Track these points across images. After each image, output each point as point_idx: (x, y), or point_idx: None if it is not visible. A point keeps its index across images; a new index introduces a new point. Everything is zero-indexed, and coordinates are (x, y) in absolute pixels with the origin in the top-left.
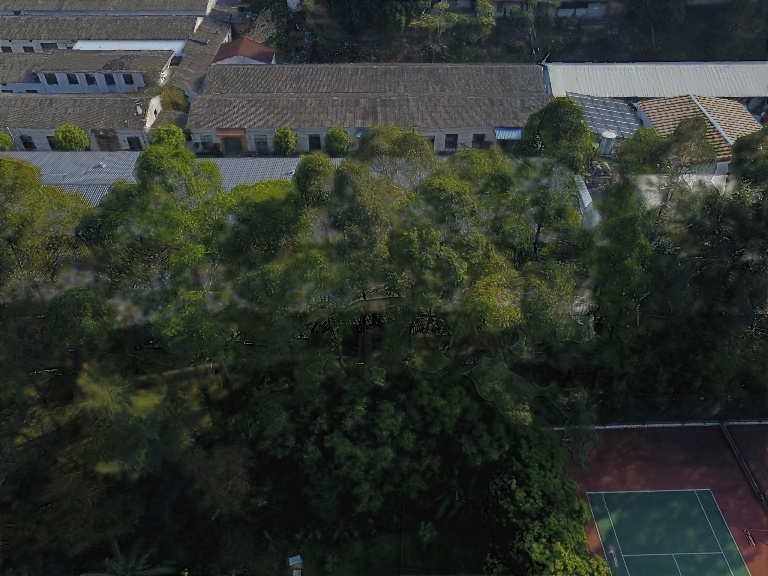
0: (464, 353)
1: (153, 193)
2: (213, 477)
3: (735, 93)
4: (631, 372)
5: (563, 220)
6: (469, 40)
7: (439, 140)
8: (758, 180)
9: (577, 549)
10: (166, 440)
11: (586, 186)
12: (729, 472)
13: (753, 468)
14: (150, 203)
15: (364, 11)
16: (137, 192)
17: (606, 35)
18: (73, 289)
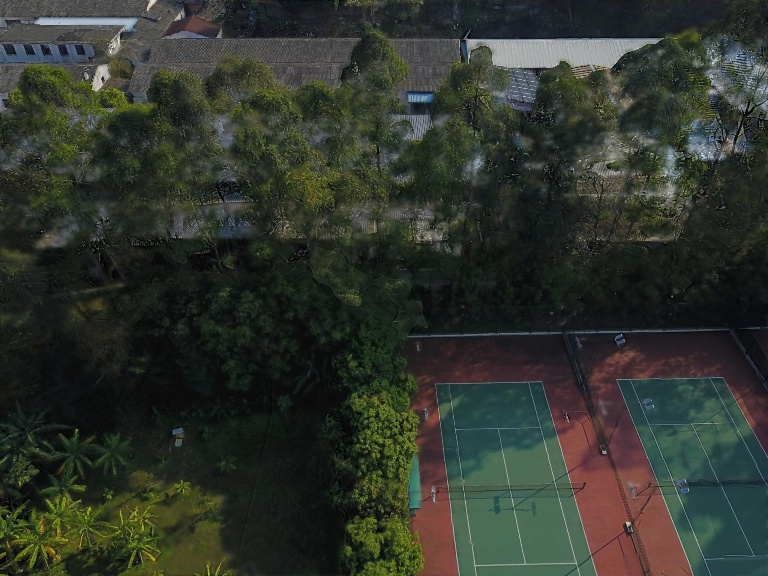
0: None
1: (35, 102)
2: (91, 341)
3: None
4: (481, 285)
5: (396, 141)
6: (400, 18)
7: None
8: (547, 103)
9: (396, 407)
10: (51, 309)
11: None
12: (561, 369)
13: (582, 366)
14: (32, 110)
15: None
16: (22, 102)
17: (528, 14)
18: None
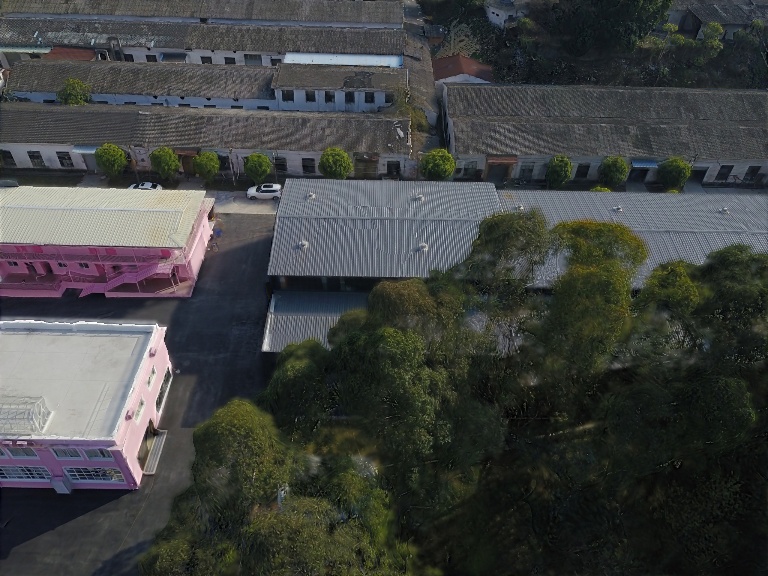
0: None
1: None
2: None
3: None
4: None
5: None
6: (690, 63)
7: (712, 171)
8: None
9: None
10: None
11: None
12: None
13: None
14: None
15: (597, 31)
16: None
17: None
18: (649, 365)
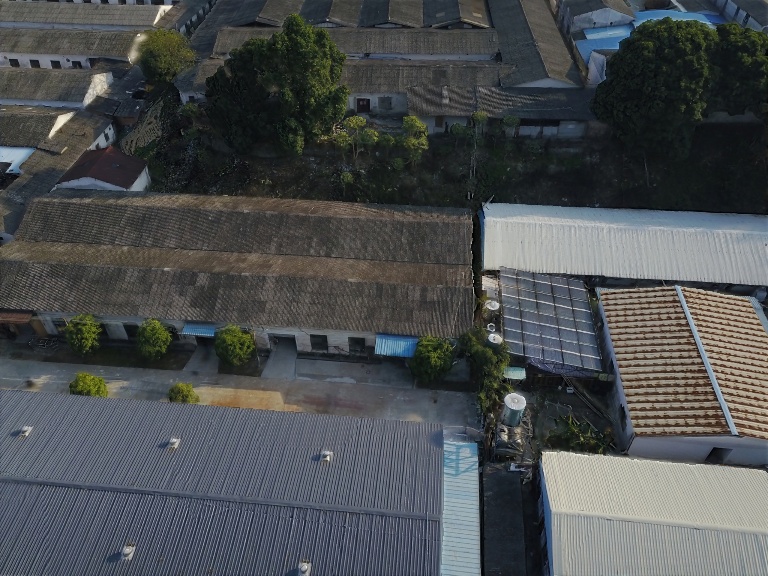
0: None
1: None
2: None
3: (749, 279)
4: None
5: None
6: None
7: (302, 340)
8: None
9: None
10: None
11: None
12: None
13: None
14: None
15: (248, 128)
16: None
17: (582, 163)
18: None
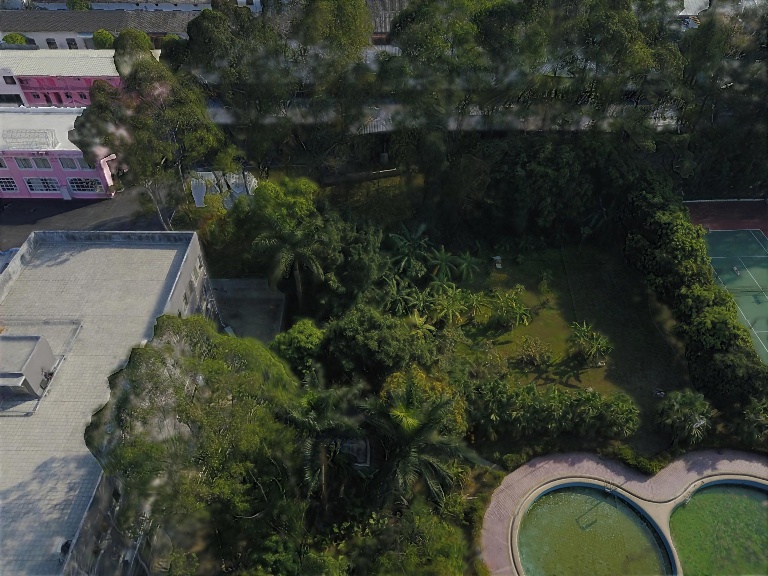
0: (605, 126)
1: None
2: (473, 171)
3: None
4: (705, 159)
5: None
6: None
7: None
8: None
9: None
10: None
11: None
12: None
13: None
14: None
15: None
16: None
17: None
18: None
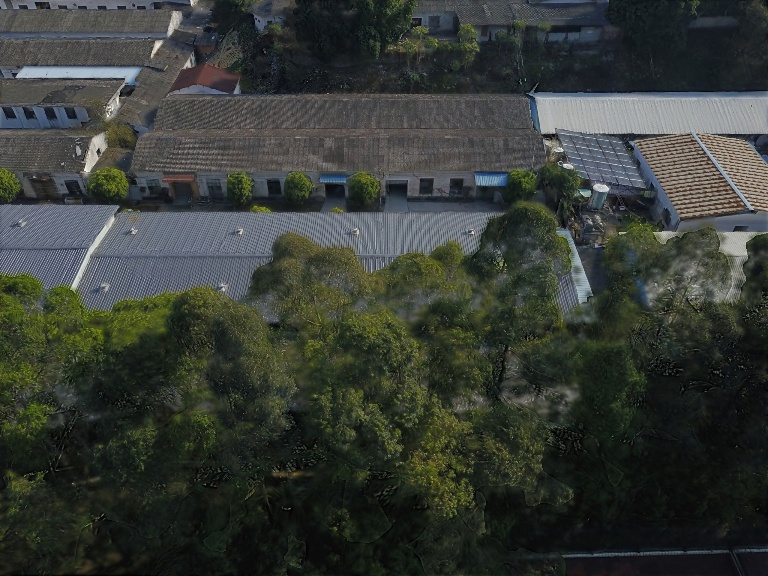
0: (416, 493)
1: None
2: None
3: (742, 130)
4: (623, 495)
5: (537, 338)
6: (451, 67)
7: (413, 185)
8: None
9: None
10: None
11: (575, 243)
12: None
13: None
14: None
15: (335, 36)
16: None
17: (600, 61)
18: None
